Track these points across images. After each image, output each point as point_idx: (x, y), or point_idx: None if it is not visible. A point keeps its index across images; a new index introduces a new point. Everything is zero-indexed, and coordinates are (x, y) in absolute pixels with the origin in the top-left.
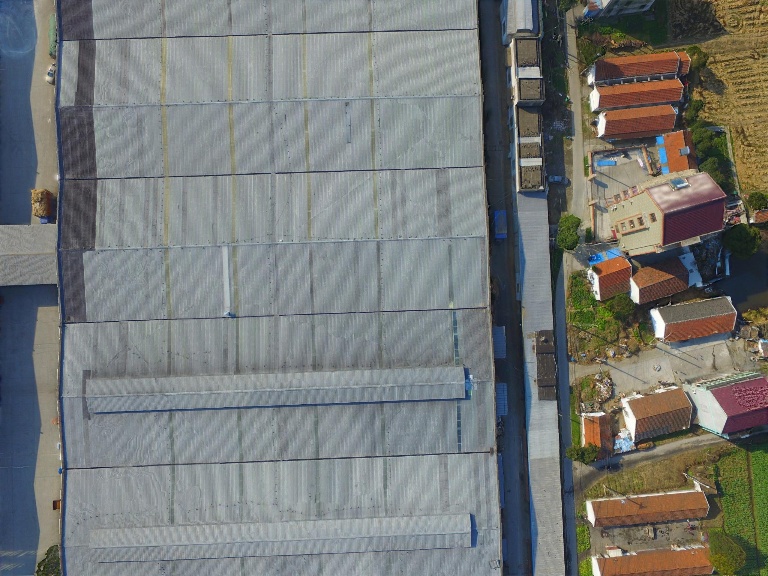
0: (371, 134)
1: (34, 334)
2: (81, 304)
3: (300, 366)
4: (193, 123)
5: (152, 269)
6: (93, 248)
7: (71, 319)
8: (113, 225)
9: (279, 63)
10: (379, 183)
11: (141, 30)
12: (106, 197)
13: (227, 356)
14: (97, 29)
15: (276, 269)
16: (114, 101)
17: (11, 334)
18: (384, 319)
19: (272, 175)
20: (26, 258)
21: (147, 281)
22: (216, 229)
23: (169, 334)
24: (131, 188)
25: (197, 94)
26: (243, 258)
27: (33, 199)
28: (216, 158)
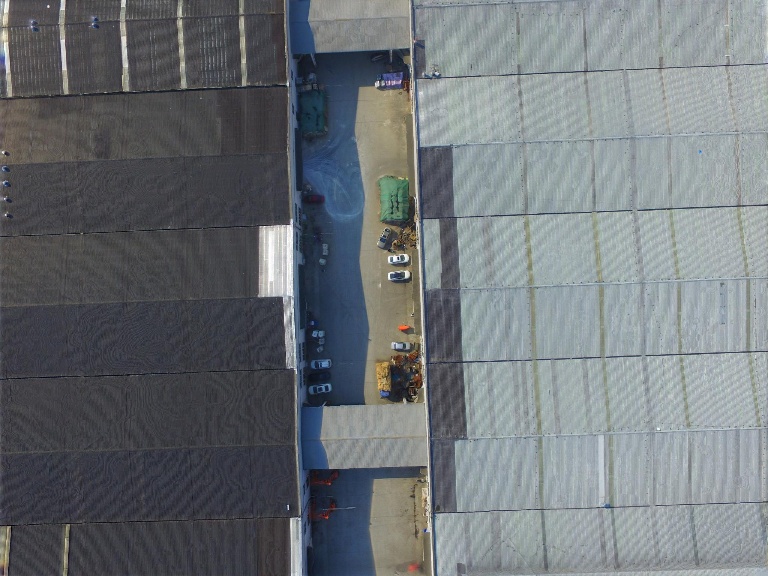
0: (746, 315)
1: (370, 507)
2: (451, 493)
3: (682, 561)
4: (562, 305)
5: (526, 458)
6: (465, 437)
7: (441, 508)
8: (484, 412)
9: (647, 241)
10: (755, 366)
11: (503, 207)
12: (474, 382)
13: (605, 549)
14: (458, 207)
15: (653, 458)
16: (481, 283)
17: (347, 506)
18: (766, 510)
19: (643, 358)
20: (387, 441)
21: (520, 470)
22: (590, 416)
23: (543, 525)
24: (499, 372)
25: (566, 275)
26: (619, 447)
27: (380, 374)
28: (585, 340)
